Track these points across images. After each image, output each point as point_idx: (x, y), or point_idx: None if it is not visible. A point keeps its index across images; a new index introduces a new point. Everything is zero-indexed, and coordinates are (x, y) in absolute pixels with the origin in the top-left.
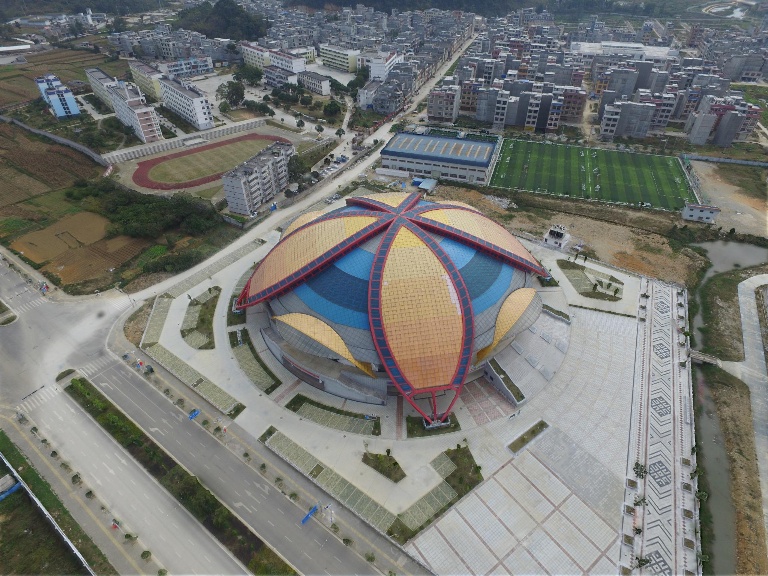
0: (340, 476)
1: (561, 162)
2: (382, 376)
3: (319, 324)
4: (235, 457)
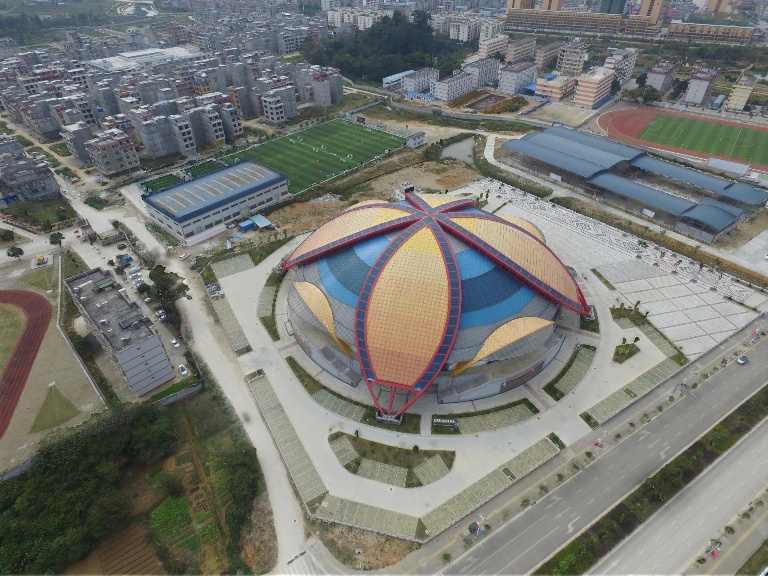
0: (634, 380)
1: (294, 153)
2: (555, 319)
3: (515, 323)
4: (611, 452)
